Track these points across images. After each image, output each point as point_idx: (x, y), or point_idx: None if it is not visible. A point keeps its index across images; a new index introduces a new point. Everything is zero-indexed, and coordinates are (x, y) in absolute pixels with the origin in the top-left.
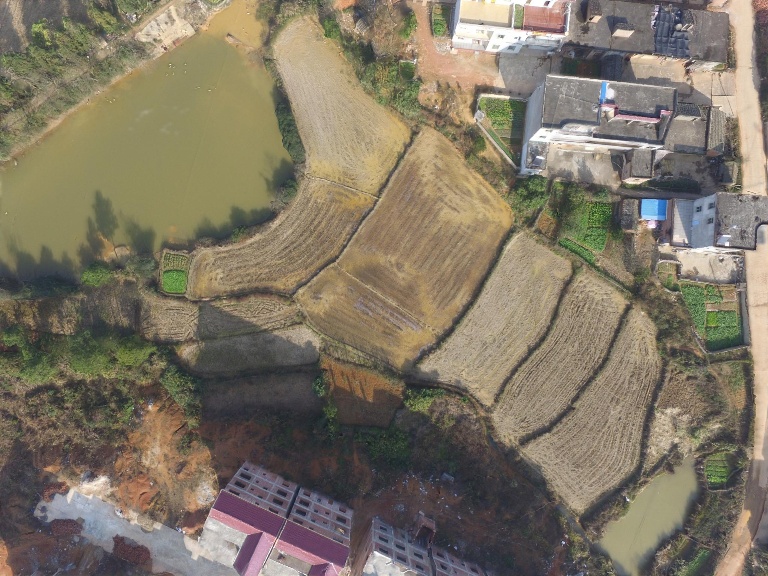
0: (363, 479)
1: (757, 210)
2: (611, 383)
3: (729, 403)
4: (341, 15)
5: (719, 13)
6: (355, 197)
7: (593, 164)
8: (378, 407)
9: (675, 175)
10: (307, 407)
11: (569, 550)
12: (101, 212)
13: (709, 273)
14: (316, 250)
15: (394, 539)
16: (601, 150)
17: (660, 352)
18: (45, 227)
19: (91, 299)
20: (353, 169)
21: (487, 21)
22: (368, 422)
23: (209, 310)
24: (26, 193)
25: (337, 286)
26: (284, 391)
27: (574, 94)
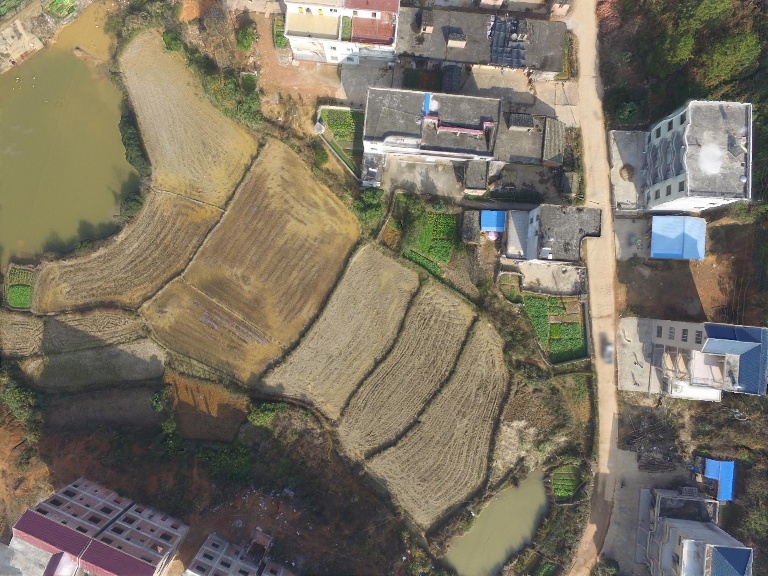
0: (200, 495)
1: (581, 222)
2: (457, 396)
3: (573, 416)
4: (187, 27)
5: (556, 22)
6: (202, 210)
7: (436, 175)
8: (222, 421)
9: (518, 186)
10: (151, 422)
11: (408, 566)
12: None
13: (552, 284)
14: (162, 264)
15: (221, 556)
16: (443, 161)
17: (506, 364)
18: None
19: None
20: (200, 182)
21: (315, 33)
22: (212, 437)
23: (54, 325)
24: None
25: (182, 300)
26: (128, 406)
27: (397, 106)
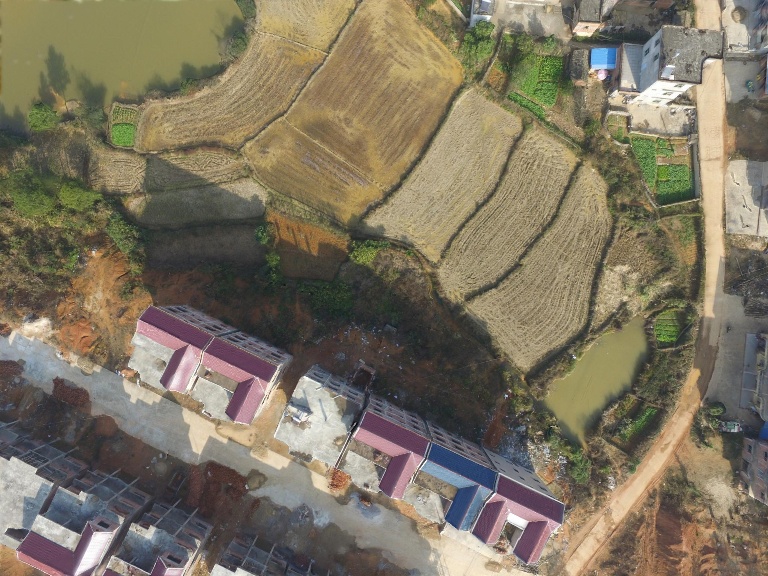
0: (304, 326)
1: (703, 44)
2: (560, 240)
3: (679, 259)
4: None
5: None
6: (305, 53)
7: (544, 17)
8: (323, 261)
9: (627, 27)
10: (252, 259)
11: (511, 402)
12: (53, 67)
13: (660, 126)
14: (265, 105)
15: (330, 378)
16: (552, 2)
17: (610, 209)
18: None
19: (40, 151)
20: (303, 25)
21: None
22: (312, 275)
23: (157, 163)
24: None
25: (285, 140)
26: (229, 243)
27: None
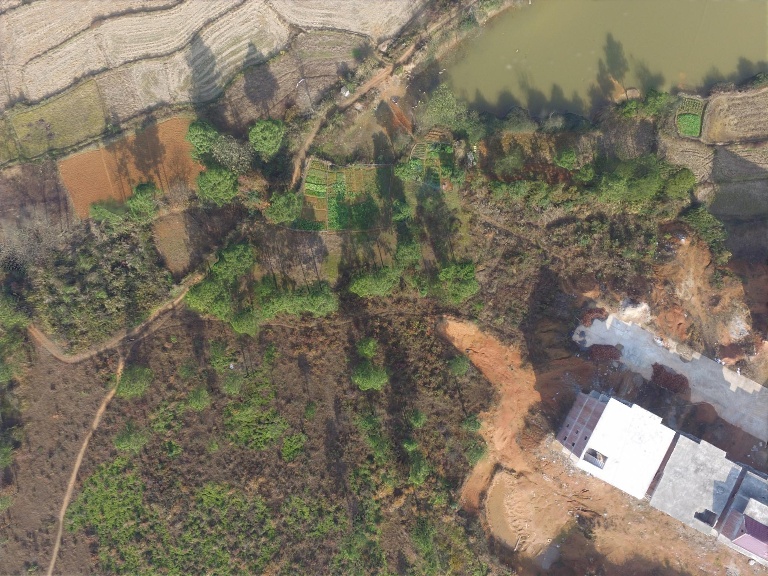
0: None
1: None
2: None
3: None
4: None
5: None
6: None
7: None
8: None
9: None
10: None
11: None
12: (612, 55)
13: None
14: None
15: None
16: None
17: None
18: (554, 67)
19: (607, 137)
20: None
21: None
22: None
23: (724, 154)
24: (537, 32)
25: None
26: None
27: None
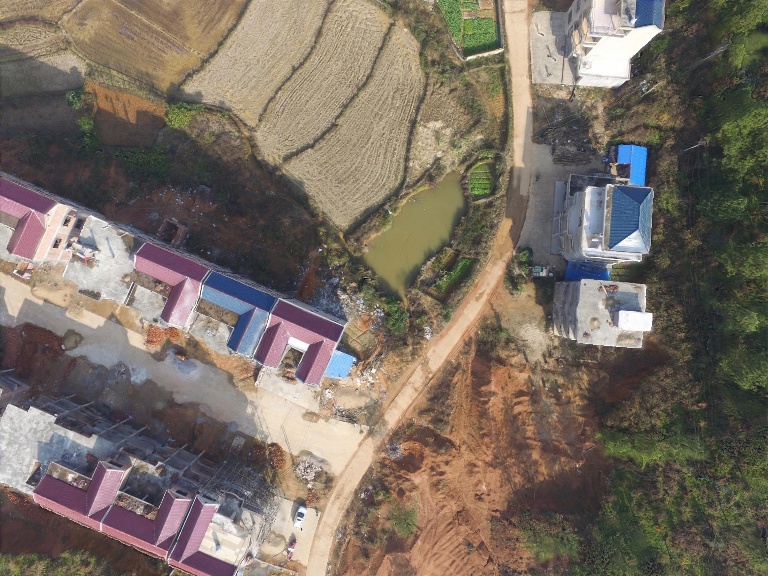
0: (117, 187)
1: None
2: (374, 99)
3: (488, 110)
4: None
5: None
6: None
7: None
8: (142, 128)
9: None
10: (71, 129)
11: None
12: None
13: None
14: None
15: (133, 229)
16: None
17: (422, 67)
18: None
19: None
20: None
21: None
22: (131, 143)
23: None
24: None
25: (102, 12)
26: (48, 114)
27: None
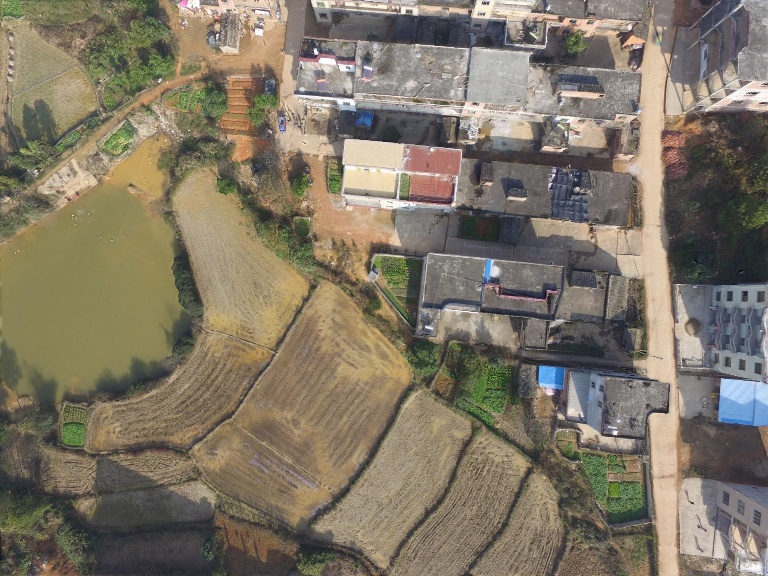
0: None
1: (648, 397)
2: (510, 550)
3: None
4: (239, 167)
5: (621, 174)
6: (252, 351)
7: (492, 325)
8: (272, 567)
9: (577, 338)
10: (201, 565)
11: None
12: (5, 362)
13: (612, 442)
14: (213, 405)
15: None
16: None
17: (562, 519)
18: None
19: None
20: (251, 322)
21: (372, 190)
22: None
23: (107, 464)
24: None
25: (233, 442)
26: (178, 548)
27: (457, 272)
